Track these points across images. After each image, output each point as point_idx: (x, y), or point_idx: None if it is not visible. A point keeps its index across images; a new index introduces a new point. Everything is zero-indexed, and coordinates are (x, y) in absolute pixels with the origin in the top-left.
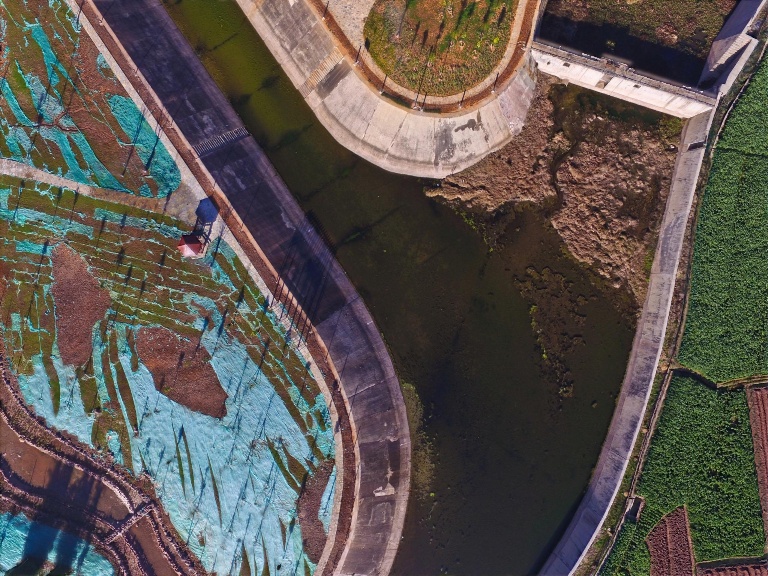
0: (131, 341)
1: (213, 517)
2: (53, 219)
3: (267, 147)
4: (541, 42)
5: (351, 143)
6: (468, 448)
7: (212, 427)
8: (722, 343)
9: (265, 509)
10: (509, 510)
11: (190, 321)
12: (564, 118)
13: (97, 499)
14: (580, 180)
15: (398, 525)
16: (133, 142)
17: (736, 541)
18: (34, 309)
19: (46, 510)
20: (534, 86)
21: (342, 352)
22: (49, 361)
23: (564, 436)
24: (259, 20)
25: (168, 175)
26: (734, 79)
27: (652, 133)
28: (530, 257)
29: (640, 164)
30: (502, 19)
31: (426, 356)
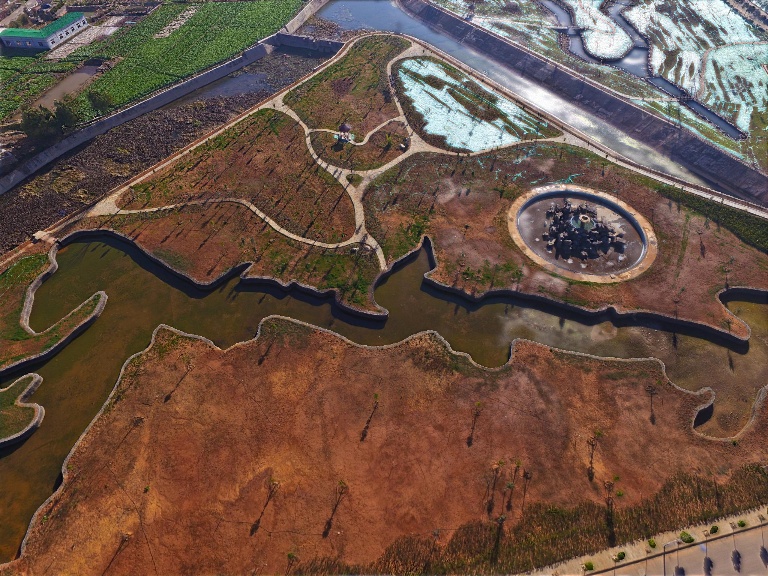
0: (492, 4)
1: None
2: None
3: None
4: None
5: None
6: None
7: None
8: None
9: None
10: None
11: None
12: None
13: None
14: None
15: None
16: None
17: None
18: None
19: None
20: None
21: None
22: None
23: (344, 1)
24: None
25: None
26: (269, 36)
27: None
28: (350, 23)
29: None
30: None
31: None
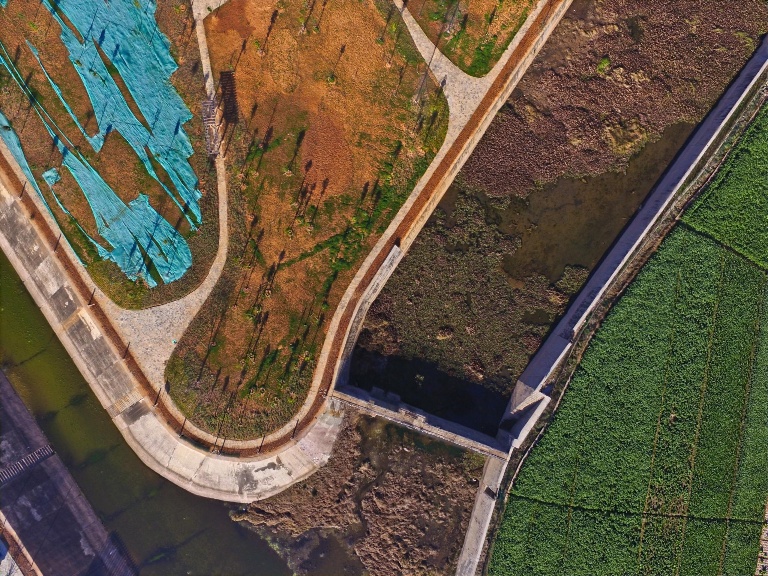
0: None
1: None
2: None
3: (72, 465)
4: (351, 374)
5: (157, 467)
6: None
7: None
8: None
9: None
10: None
11: None
12: (371, 448)
13: None
14: (384, 510)
15: None
16: None
17: None
18: None
19: None
20: (340, 420)
21: None
22: None
23: None
24: (67, 340)
25: None
26: (526, 434)
27: (456, 466)
28: None
29: (443, 495)
30: (304, 367)
31: None
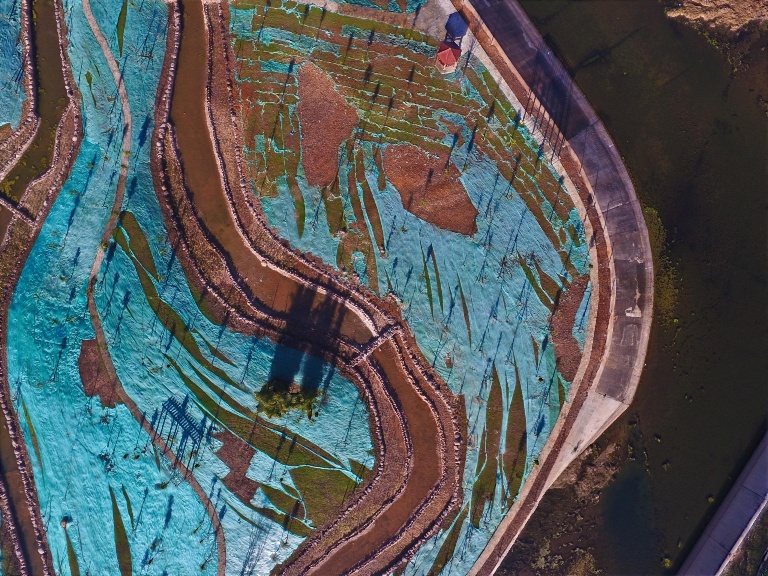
0: (378, 159)
1: (462, 337)
2: (299, 37)
3: None
4: None
5: None
6: (712, 273)
7: (462, 244)
8: None
9: (517, 327)
10: (755, 336)
11: (439, 137)
12: None
13: (340, 323)
14: None
15: (642, 351)
16: None
17: None
18: (279, 130)
19: (290, 333)
20: None
21: (593, 168)
22: (294, 182)
23: None
24: None
25: None
26: None
27: None
28: None
29: None
30: None
31: (668, 180)
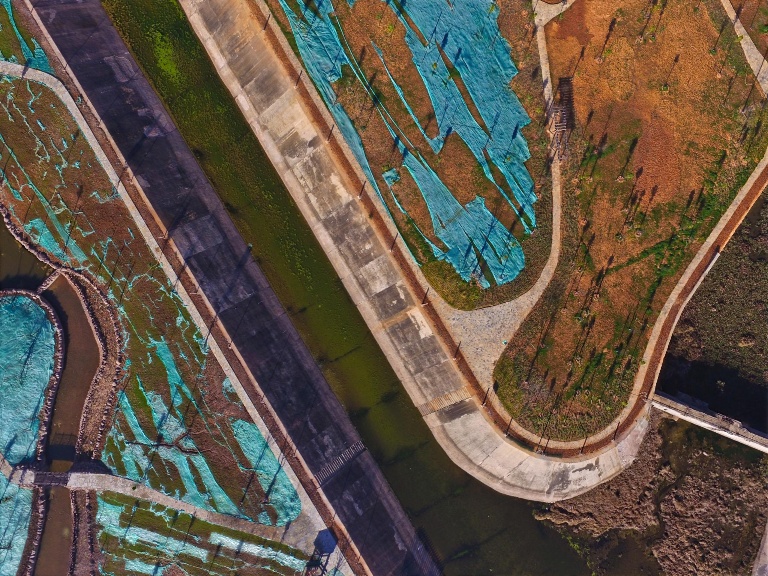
0: None
1: None
2: (166, 540)
3: (382, 461)
4: None
5: (466, 465)
6: None
7: None
8: None
9: None
10: None
11: None
12: (671, 451)
13: None
14: (682, 513)
15: None
16: (254, 468)
17: None
18: None
19: None
20: (647, 424)
21: None
22: None
23: None
24: (384, 338)
25: (288, 503)
26: None
27: (752, 471)
28: None
29: (739, 500)
30: None
31: None
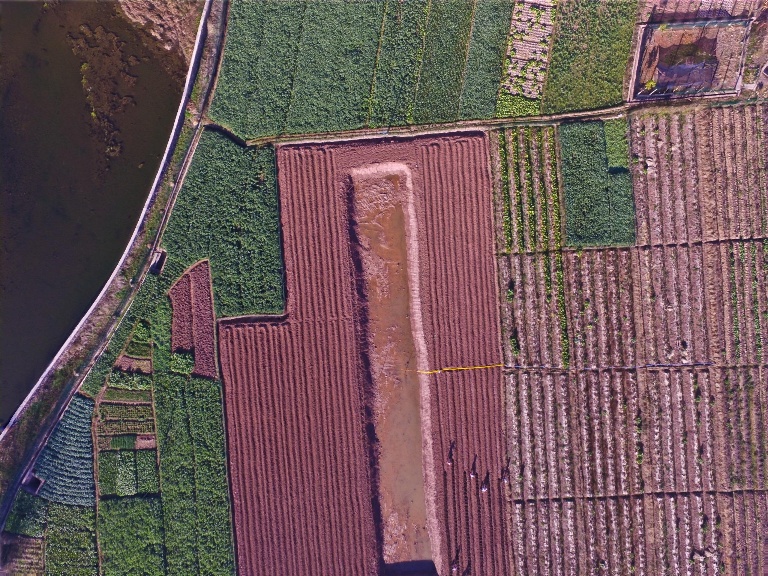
0: None
1: None
2: None
3: None
4: None
5: None
6: (14, 203)
7: None
8: (250, 99)
9: None
10: (52, 268)
11: None
12: None
13: None
14: None
15: None
16: None
17: (255, 297)
18: None
19: None
20: None
21: None
22: None
23: (111, 197)
24: None
25: None
26: None
27: None
28: (85, 15)
29: None
30: None
31: None
